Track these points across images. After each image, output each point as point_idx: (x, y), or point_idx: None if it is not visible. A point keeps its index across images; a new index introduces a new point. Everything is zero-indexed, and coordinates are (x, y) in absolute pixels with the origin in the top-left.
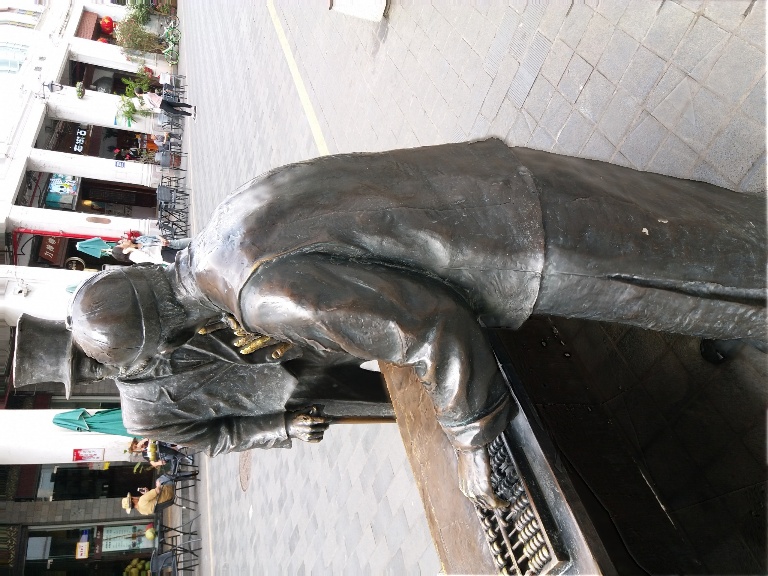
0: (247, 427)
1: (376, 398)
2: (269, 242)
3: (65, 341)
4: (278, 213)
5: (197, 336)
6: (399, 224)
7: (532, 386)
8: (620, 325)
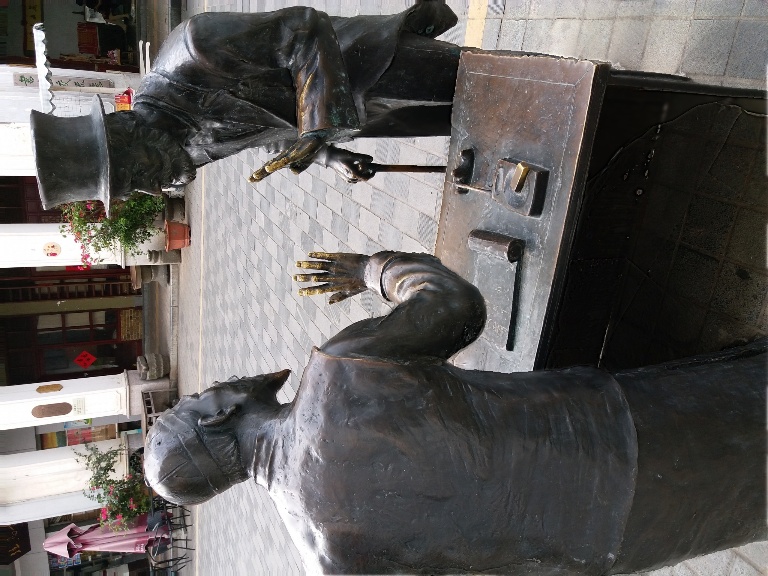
0: (285, 144)
1: (430, 133)
2: (347, 567)
3: (95, 182)
4: (365, 543)
5: (246, 112)
6: (468, 573)
7: (577, 238)
8: (698, 239)
